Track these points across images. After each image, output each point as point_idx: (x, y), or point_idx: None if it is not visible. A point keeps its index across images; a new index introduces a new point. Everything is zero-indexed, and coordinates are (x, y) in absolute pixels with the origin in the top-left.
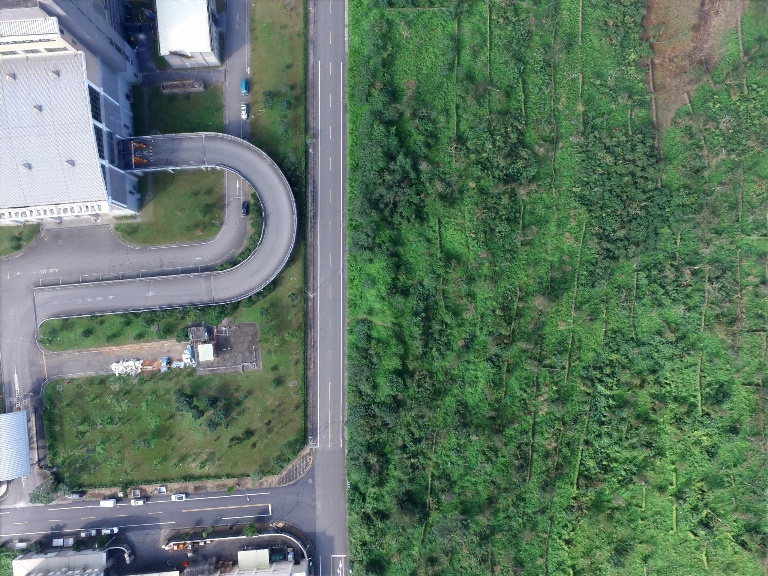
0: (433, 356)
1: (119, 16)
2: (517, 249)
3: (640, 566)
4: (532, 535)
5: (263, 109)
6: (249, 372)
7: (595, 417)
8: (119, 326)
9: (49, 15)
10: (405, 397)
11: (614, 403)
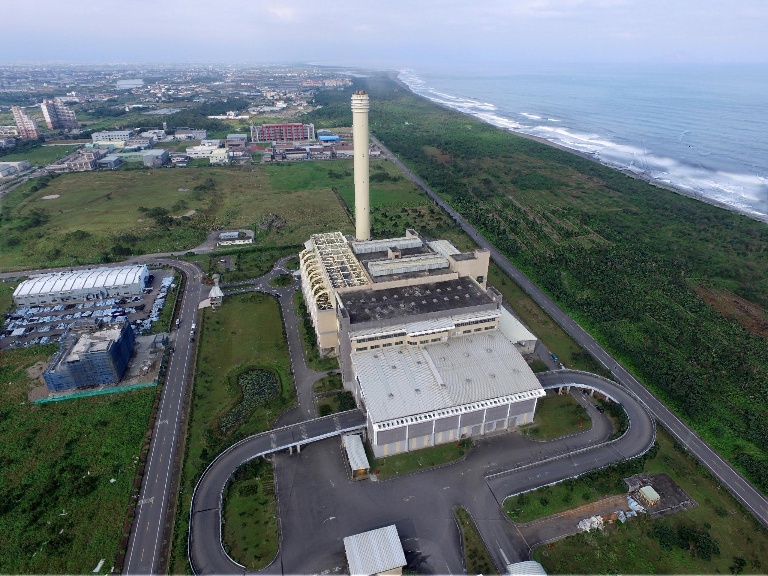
0: None
1: None
2: None
3: None
4: None
5: (571, 365)
6: (691, 509)
7: None
8: (565, 493)
9: (497, 308)
10: None
11: None
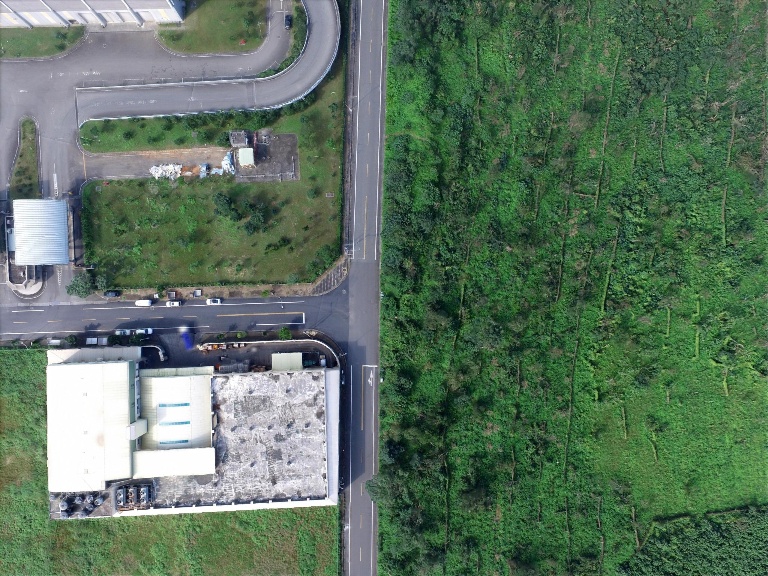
0: (468, 173)
1: None
2: (552, 76)
3: (663, 391)
4: (559, 354)
5: None
6: (287, 182)
7: (623, 243)
8: (160, 130)
9: None
10: (440, 210)
11: (642, 230)
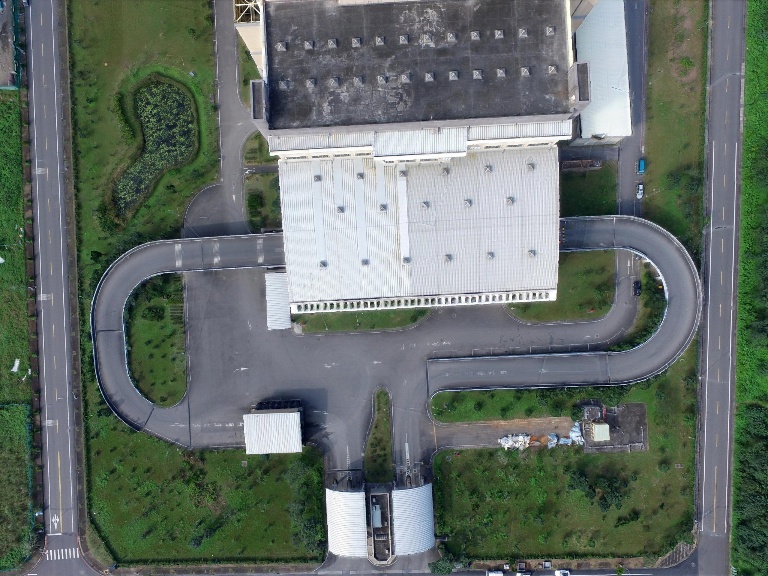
0: None
1: None
2: None
3: None
4: None
5: (658, 189)
6: (636, 452)
7: None
8: (509, 401)
9: (568, 118)
10: None
11: None
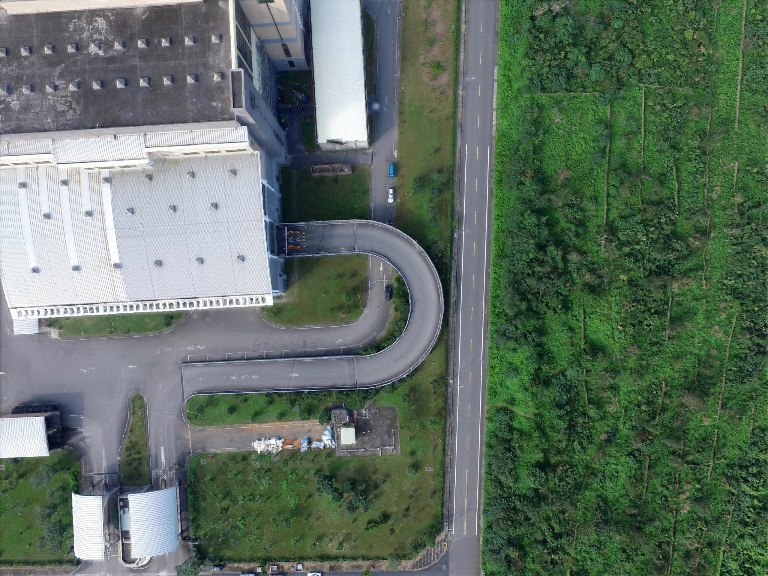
0: (574, 449)
1: (275, 101)
2: (663, 342)
3: None
4: None
5: (409, 193)
6: (387, 455)
7: (739, 518)
8: (262, 404)
9: (241, 125)
10: (545, 490)
11: (760, 505)
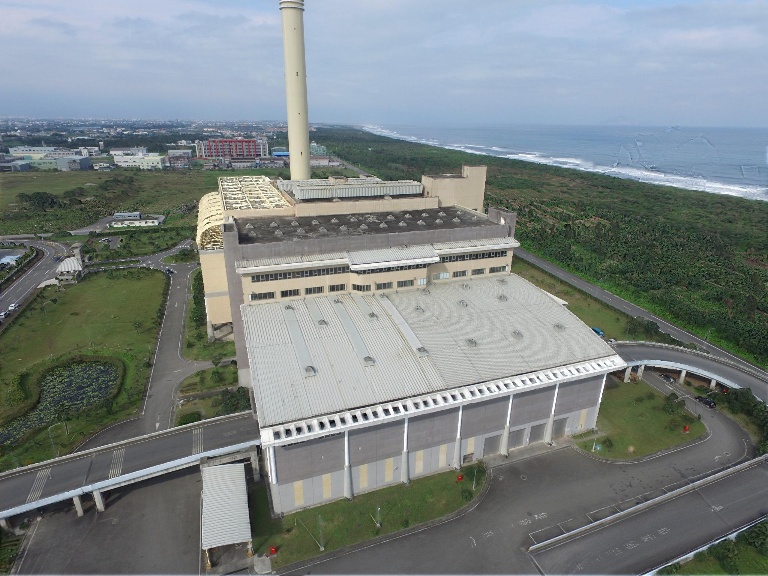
0: None
1: None
2: None
3: None
4: None
5: None
6: None
7: None
8: None
9: (507, 236)
10: None
11: None
